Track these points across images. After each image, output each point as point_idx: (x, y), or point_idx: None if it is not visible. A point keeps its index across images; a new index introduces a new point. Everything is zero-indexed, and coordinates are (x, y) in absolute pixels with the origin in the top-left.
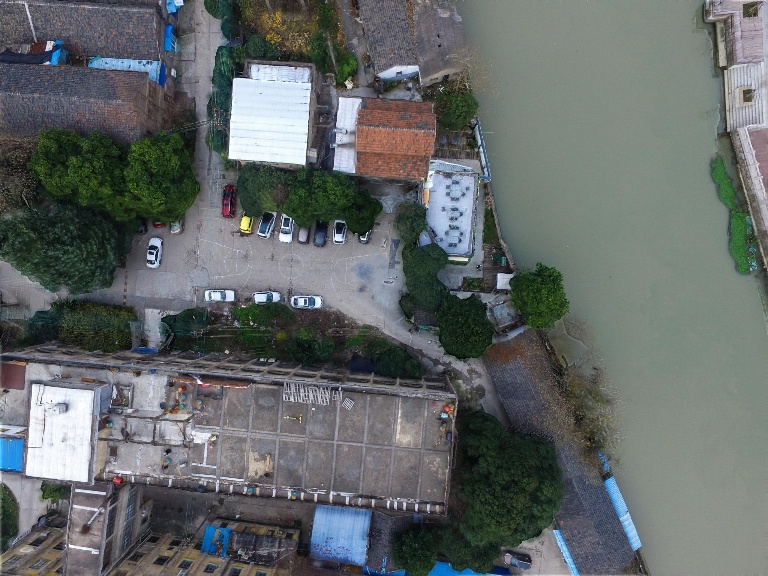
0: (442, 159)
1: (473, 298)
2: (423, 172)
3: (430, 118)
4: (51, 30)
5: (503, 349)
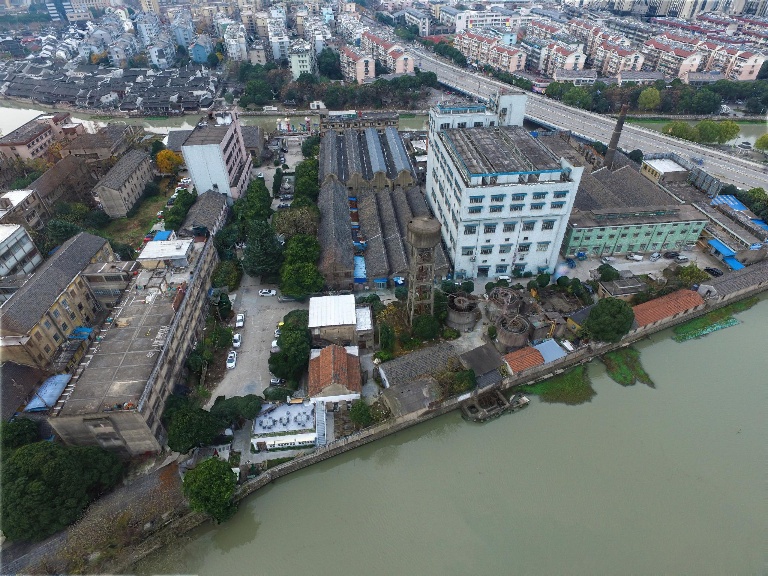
0: (333, 422)
1: (215, 431)
2: (313, 394)
3: (344, 382)
4: (372, 243)
5: (172, 472)
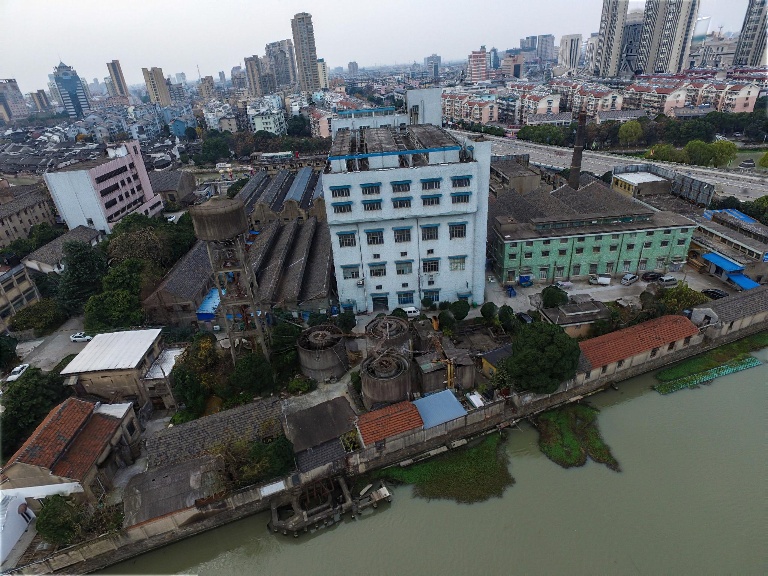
0: (35, 536)
1: None
2: None
3: (43, 461)
4: None
5: None
